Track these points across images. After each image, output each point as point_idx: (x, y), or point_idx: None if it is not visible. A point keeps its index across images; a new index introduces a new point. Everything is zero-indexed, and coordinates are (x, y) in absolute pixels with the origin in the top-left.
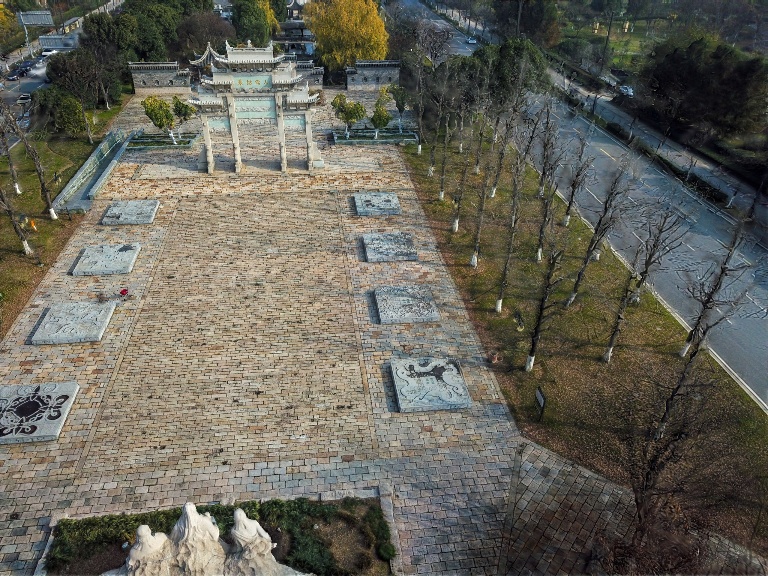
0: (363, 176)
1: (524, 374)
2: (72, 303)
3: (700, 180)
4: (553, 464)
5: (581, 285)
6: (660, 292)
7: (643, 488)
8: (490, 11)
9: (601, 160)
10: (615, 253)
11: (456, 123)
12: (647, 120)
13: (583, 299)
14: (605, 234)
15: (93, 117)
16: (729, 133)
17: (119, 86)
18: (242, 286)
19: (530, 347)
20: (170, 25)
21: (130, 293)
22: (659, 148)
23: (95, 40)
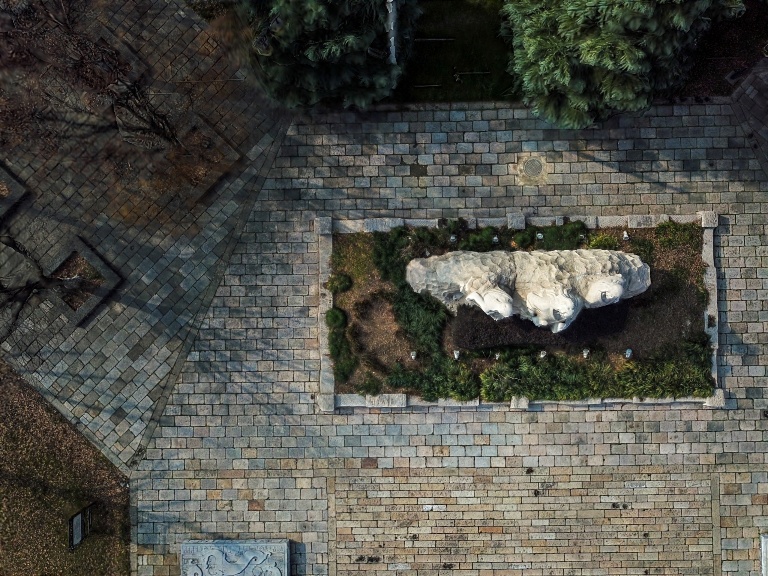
0: None
1: None
2: None
3: None
4: (103, 426)
5: None
6: None
7: (4, 378)
8: None
9: None
10: None
11: None
12: None
13: None
14: None
15: None
16: None
17: None
18: None
19: None
20: None
21: None
22: None
23: None
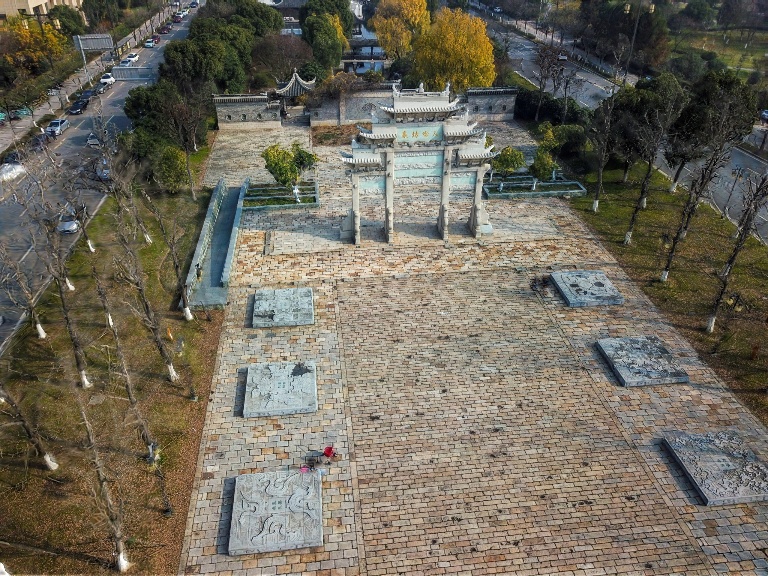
0: (545, 245)
1: None
2: (263, 474)
3: None
4: None
5: None
6: None
7: None
8: (583, 24)
9: None
10: None
11: (700, 188)
12: None
13: None
14: None
15: None
16: None
17: (206, 123)
18: (478, 433)
19: None
20: (245, 48)
21: None
22: None
23: (179, 71)
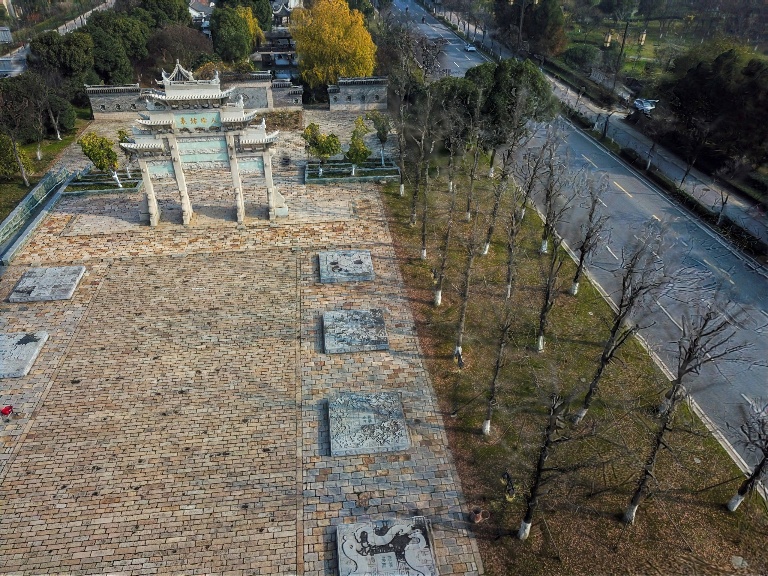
0: (333, 226)
1: (517, 544)
2: None
3: (734, 225)
4: None
5: (594, 397)
6: (695, 396)
7: None
8: (490, 15)
9: (615, 197)
10: (636, 334)
11: None
12: (667, 143)
13: (596, 412)
14: (625, 340)
15: (37, 152)
16: (765, 163)
17: (72, 113)
18: (162, 395)
19: (526, 495)
20: (139, 40)
21: (18, 408)
22: (683, 182)
23: (44, 63)
